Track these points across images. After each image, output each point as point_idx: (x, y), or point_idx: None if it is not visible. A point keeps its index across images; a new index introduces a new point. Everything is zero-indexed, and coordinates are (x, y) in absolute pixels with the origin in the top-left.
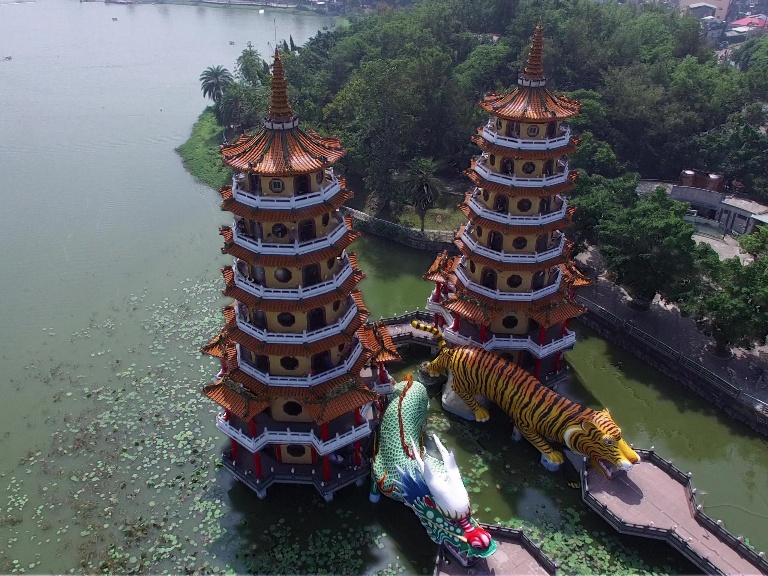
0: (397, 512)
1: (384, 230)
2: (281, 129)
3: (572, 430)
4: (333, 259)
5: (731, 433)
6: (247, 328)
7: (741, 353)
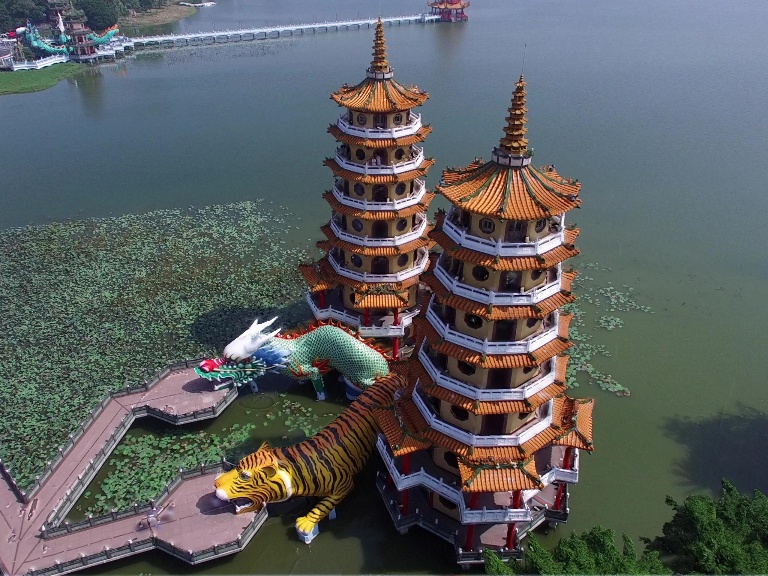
0: None
1: None
2: None
3: None
4: None
5: None
6: None
7: None
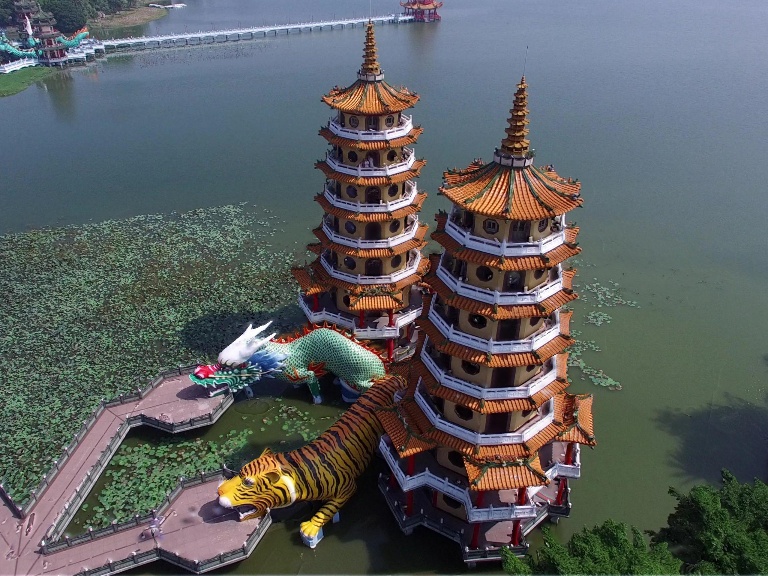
0: None
1: None
2: None
3: None
4: (357, 194)
5: None
6: None
7: None
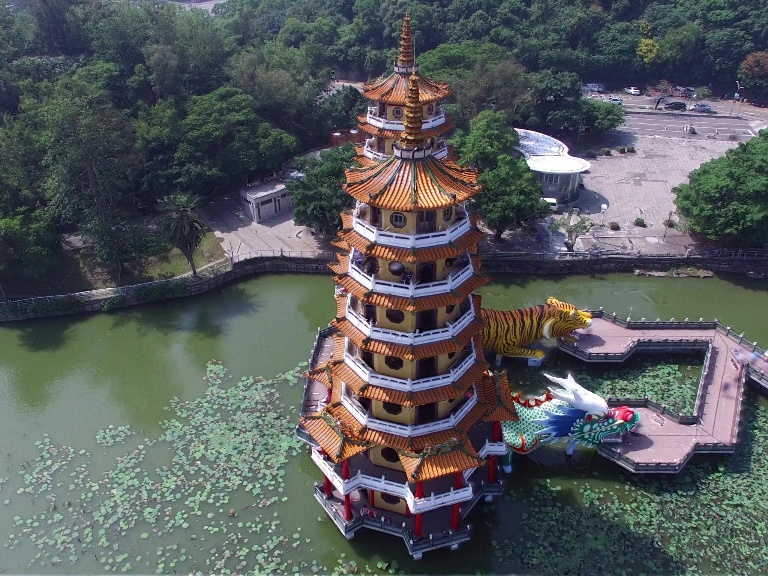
0: (521, 466)
1: (153, 293)
2: (429, 154)
3: (549, 324)
4: None
5: (557, 282)
6: (425, 384)
7: (506, 236)
